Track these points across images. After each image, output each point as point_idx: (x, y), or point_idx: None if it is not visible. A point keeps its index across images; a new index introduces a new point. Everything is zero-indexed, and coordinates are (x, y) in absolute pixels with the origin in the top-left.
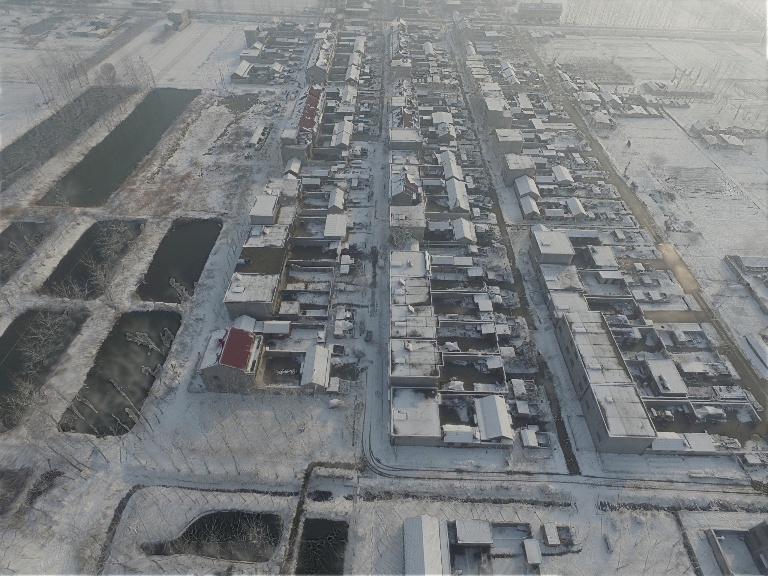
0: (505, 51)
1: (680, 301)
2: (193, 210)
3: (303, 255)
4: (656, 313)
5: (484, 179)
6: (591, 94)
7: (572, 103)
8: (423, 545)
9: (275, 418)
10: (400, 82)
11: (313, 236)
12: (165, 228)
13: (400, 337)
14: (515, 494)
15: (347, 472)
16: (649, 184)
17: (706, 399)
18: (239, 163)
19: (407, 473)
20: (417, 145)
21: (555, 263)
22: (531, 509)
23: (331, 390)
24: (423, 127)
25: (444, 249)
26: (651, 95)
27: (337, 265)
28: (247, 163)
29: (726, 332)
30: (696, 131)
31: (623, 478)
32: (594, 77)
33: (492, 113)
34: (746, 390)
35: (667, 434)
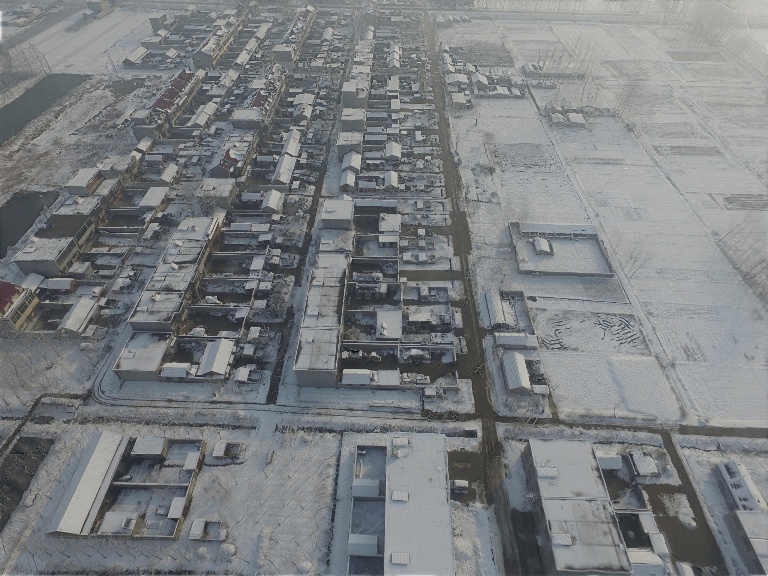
0: (404, 36)
1: (446, 262)
2: (36, 184)
3: (119, 223)
4: (417, 272)
5: (321, 155)
6: (461, 76)
7: (443, 85)
8: (93, 453)
9: (28, 358)
10: (271, 66)
11: (135, 206)
12: (3, 200)
13: (153, 290)
14: (211, 419)
15: (71, 401)
16: (476, 159)
17: (417, 343)
18: (99, 142)
19: (123, 402)
20: (256, 124)
21: (337, 228)
22: (217, 431)
23: (85, 335)
24: (284, 108)
25: (252, 218)
26: (520, 76)
27: (142, 231)
28: (106, 142)
29: (472, 288)
30: (546, 110)
31: (311, 407)
32: (478, 60)
33: (345, 94)
34: (462, 337)
35: (360, 370)
